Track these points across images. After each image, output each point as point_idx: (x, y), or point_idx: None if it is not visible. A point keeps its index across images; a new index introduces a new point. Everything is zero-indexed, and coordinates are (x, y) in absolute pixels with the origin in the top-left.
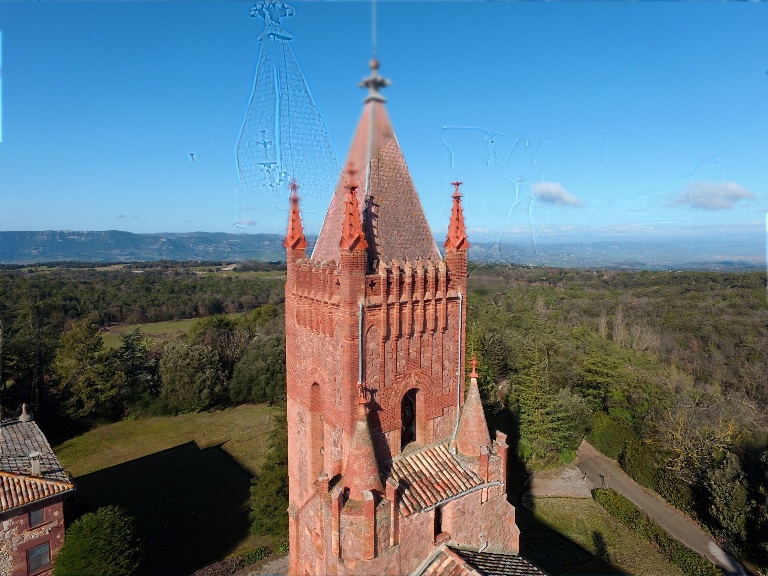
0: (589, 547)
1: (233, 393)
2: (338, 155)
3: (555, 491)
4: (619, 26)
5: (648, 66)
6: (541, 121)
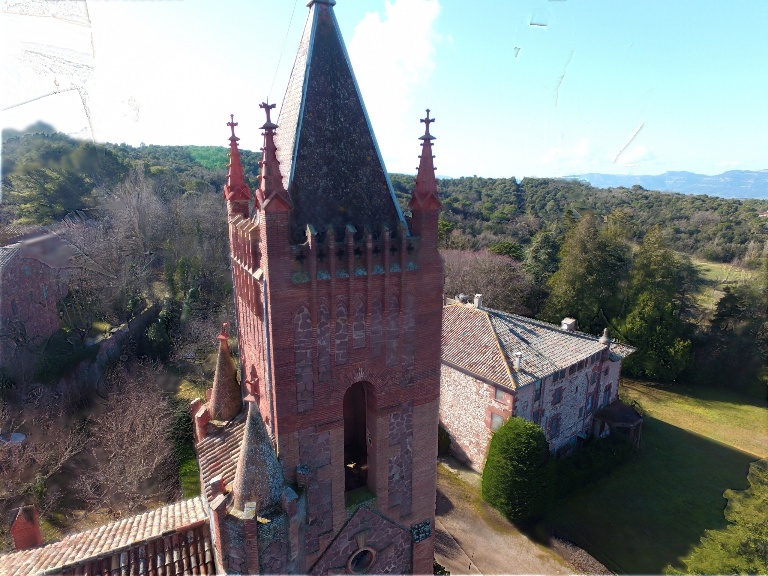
0: None
1: None
2: None
3: None
4: None
5: None
6: None
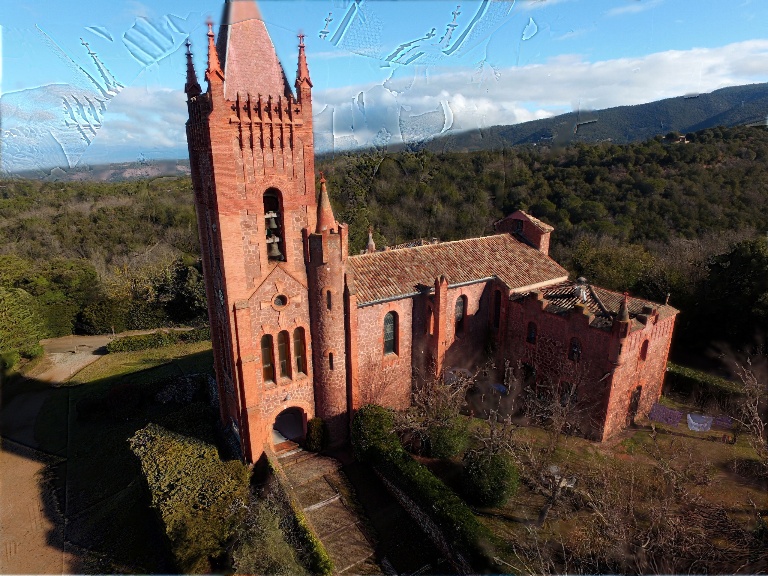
0: (160, 363)
1: None
2: None
3: (71, 369)
4: None
5: None
6: None
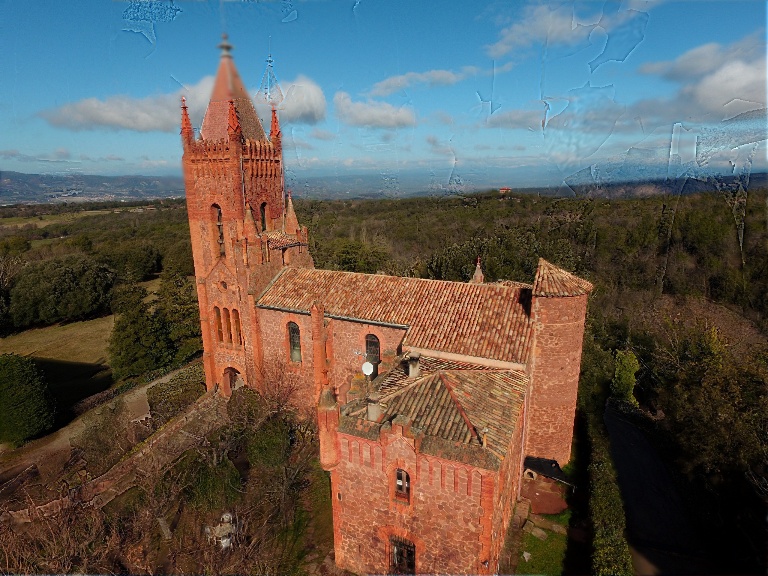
0: None
1: (17, 317)
2: (282, 92)
3: None
4: (335, 70)
5: (341, 78)
6: (320, 87)
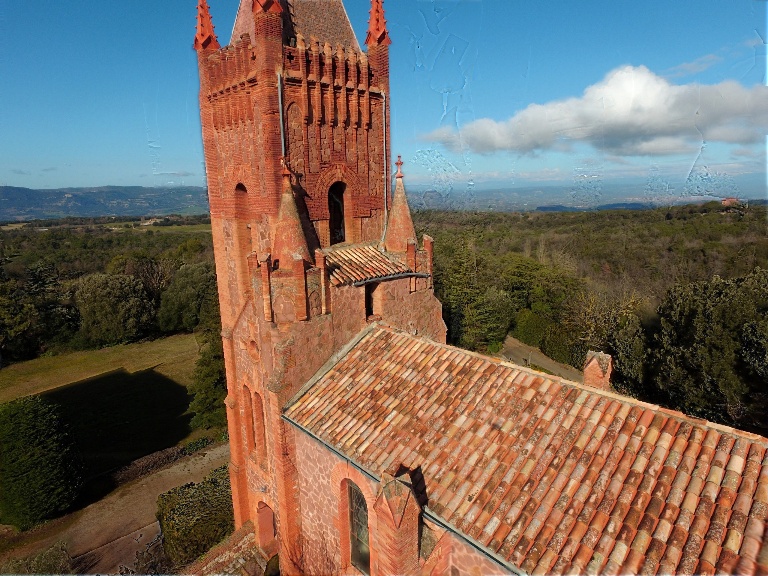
0: None
1: (162, 322)
2: None
3: None
4: None
5: None
6: None
